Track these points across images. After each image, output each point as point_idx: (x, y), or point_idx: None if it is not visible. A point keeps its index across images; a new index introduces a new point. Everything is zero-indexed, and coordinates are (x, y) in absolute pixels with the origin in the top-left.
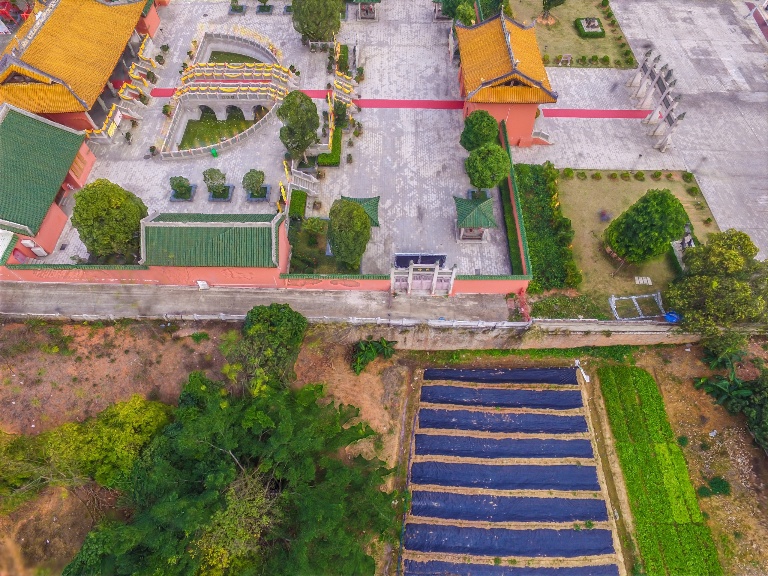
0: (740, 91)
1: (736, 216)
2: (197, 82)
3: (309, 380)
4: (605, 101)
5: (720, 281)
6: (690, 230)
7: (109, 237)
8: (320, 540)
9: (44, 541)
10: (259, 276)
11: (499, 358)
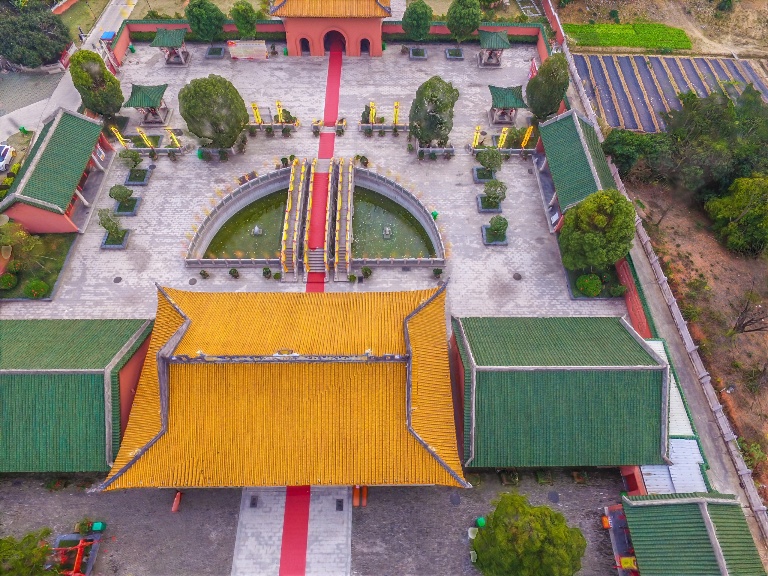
0: None
1: None
2: None
3: None
4: None
5: None
6: None
7: None
8: None
9: None
10: None
11: None
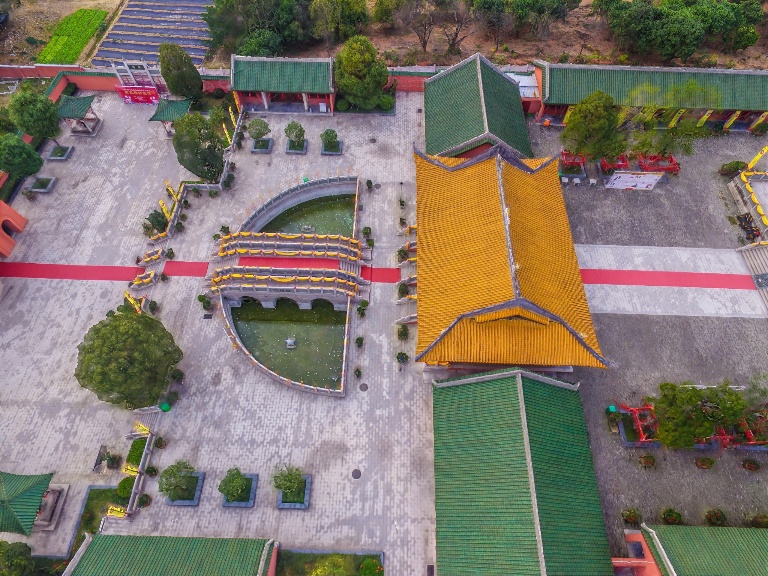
0: None
1: None
2: None
3: None
4: None
5: None
6: None
7: None
8: None
9: None
10: None
11: None
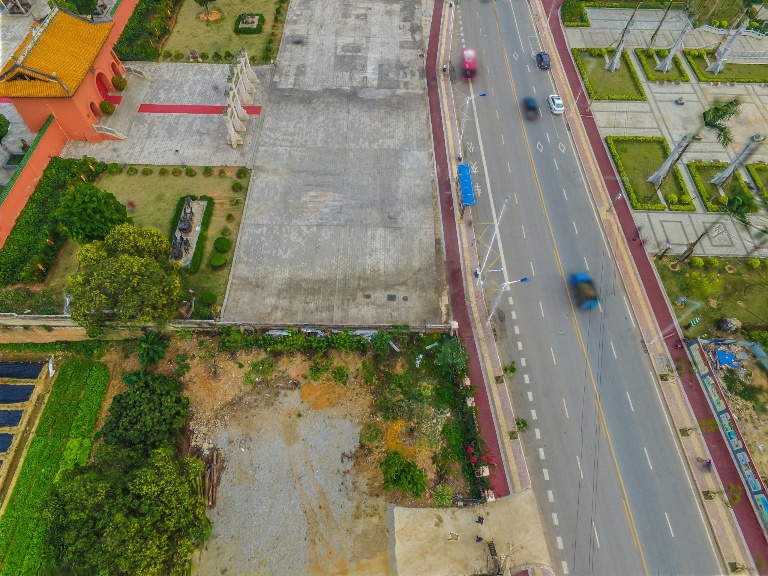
0: (364, 88)
1: (268, 212)
2: None
3: None
4: (212, 97)
5: (73, 275)
6: (186, 225)
7: None
8: None
9: None
10: None
11: None
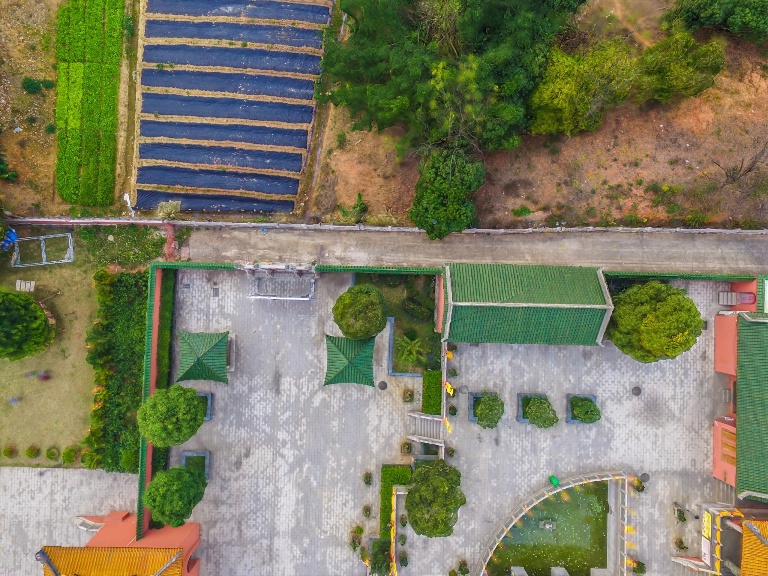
0: None
1: None
2: None
3: (409, 193)
4: None
5: None
6: None
7: None
8: None
9: None
10: None
11: None
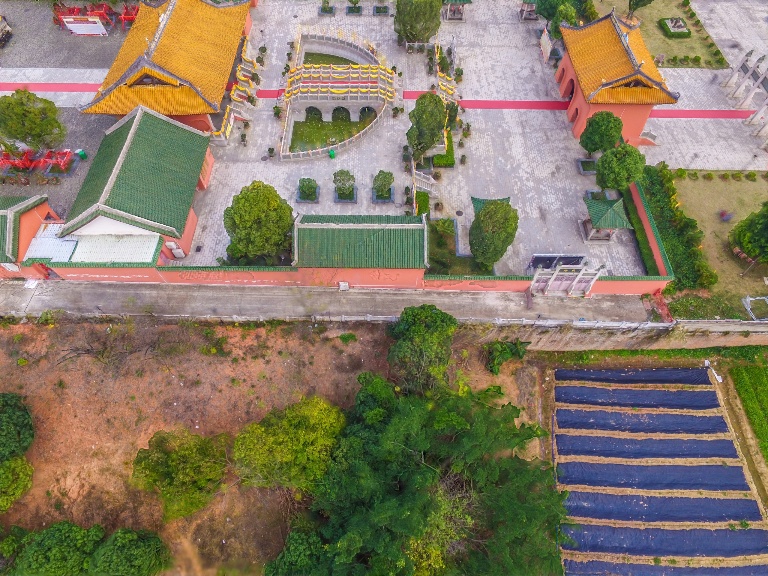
0: None
1: None
2: (305, 83)
3: None
4: (703, 101)
5: None
6: None
7: (264, 239)
8: (523, 540)
9: (220, 541)
10: (404, 277)
11: (628, 358)
